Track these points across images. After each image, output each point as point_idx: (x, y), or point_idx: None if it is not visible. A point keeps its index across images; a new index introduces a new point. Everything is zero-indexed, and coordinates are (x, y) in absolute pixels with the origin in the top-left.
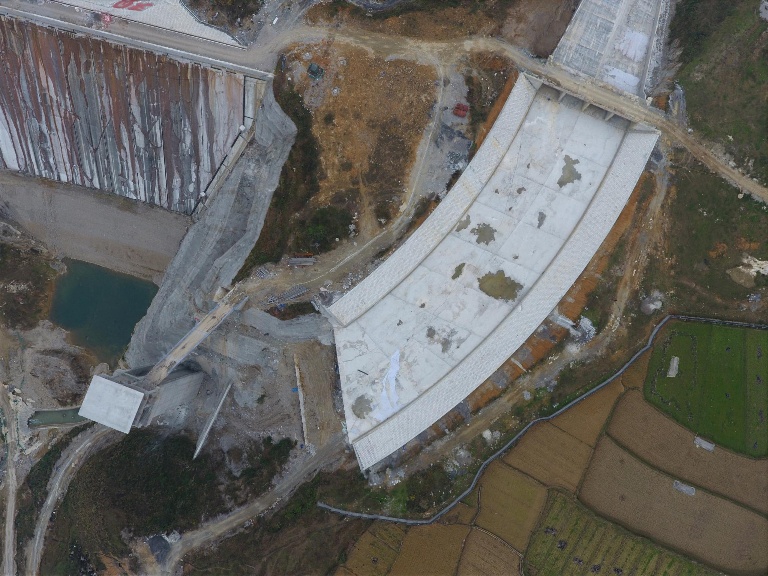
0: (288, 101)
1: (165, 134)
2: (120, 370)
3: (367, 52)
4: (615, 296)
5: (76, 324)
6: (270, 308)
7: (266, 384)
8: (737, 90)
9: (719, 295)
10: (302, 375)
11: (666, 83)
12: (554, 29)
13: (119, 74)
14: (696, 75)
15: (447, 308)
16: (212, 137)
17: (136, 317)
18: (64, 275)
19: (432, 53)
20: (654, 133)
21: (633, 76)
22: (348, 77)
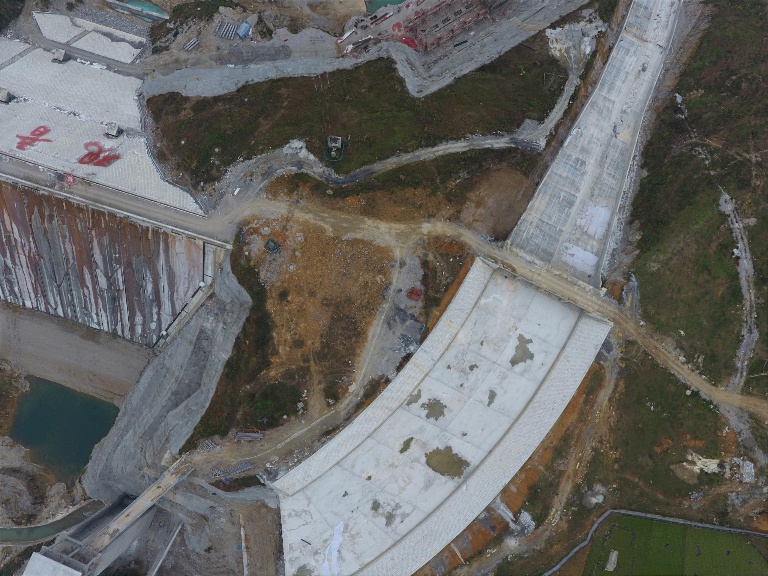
0: (244, 276)
1: (127, 280)
2: (64, 533)
3: (325, 230)
4: (557, 490)
5: (36, 441)
6: (215, 481)
7: (213, 538)
8: (692, 283)
9: (661, 491)
10: (247, 537)
11: (622, 270)
12: (515, 208)
13: (82, 228)
14: (652, 265)
15: (393, 482)
16: (173, 287)
17: (96, 437)
18: (26, 392)
19: (390, 234)
20: (606, 324)
21: (592, 255)
22: (305, 254)
